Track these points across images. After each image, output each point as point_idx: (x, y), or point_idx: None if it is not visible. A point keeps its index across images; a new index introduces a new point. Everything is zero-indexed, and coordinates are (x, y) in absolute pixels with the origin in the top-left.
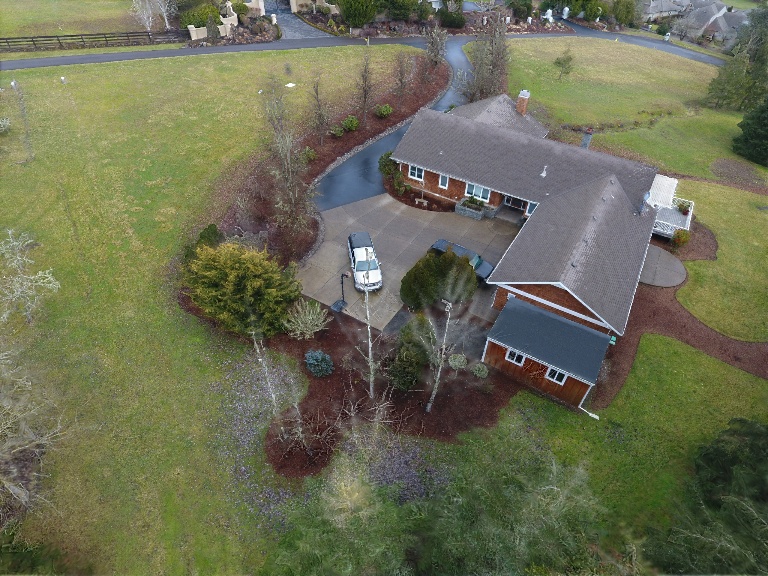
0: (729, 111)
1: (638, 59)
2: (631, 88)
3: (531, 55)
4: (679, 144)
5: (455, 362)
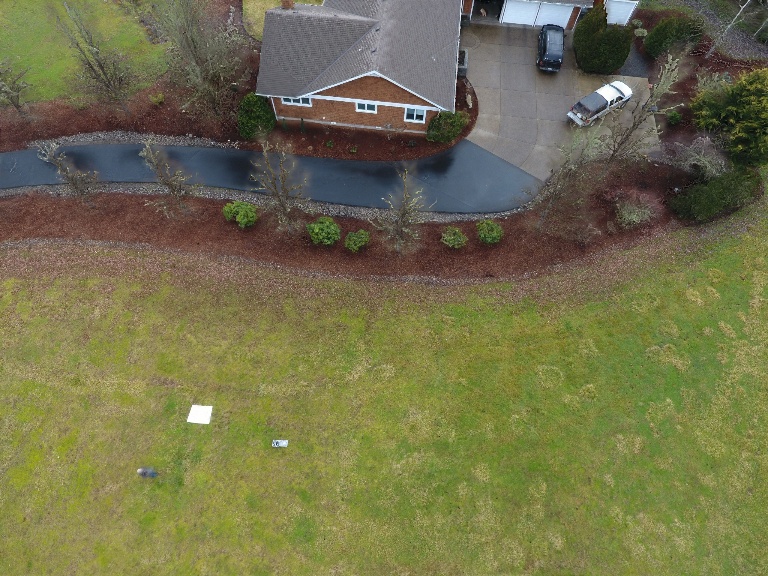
0: None
1: None
2: None
3: None
4: None
5: (645, 31)
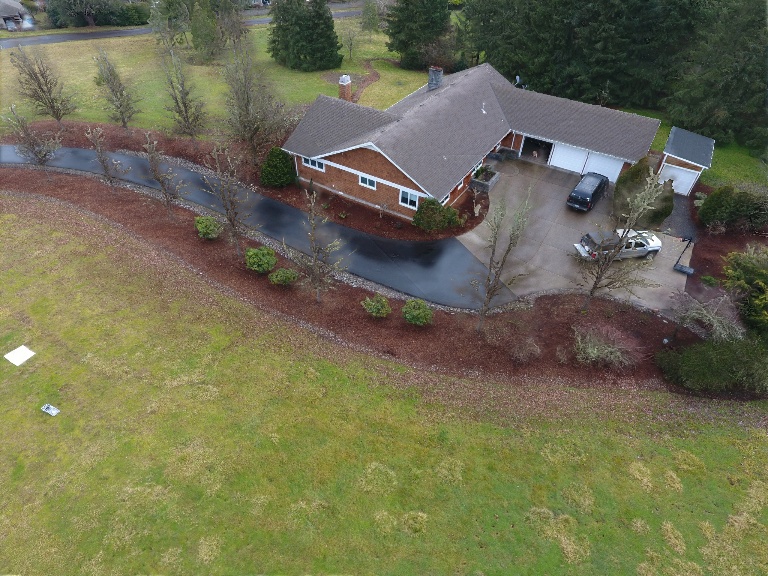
0: (217, 57)
1: (48, 59)
2: (150, 76)
3: (1, 102)
4: (294, 85)
5: None
